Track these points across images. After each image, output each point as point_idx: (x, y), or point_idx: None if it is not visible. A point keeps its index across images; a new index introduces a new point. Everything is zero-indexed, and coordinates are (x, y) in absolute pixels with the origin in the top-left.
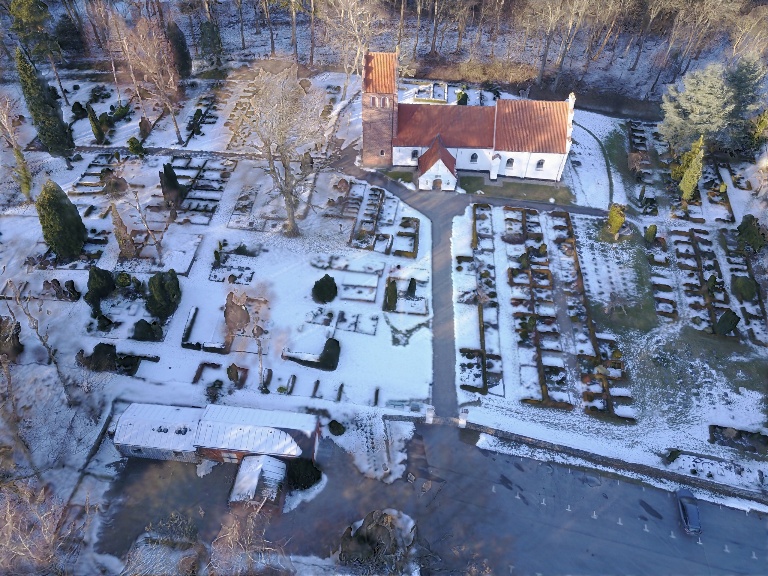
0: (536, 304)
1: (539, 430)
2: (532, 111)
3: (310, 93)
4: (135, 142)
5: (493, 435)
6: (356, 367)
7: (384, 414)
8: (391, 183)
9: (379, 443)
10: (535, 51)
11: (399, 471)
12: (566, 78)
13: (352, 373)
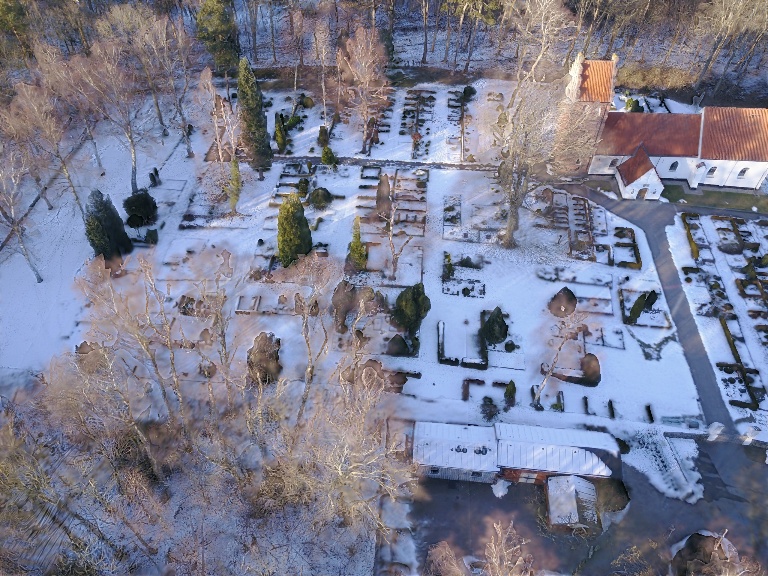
0: None
1: None
2: (740, 119)
3: (473, 100)
4: (330, 152)
5: None
6: (617, 382)
7: (665, 431)
8: (591, 192)
9: (670, 461)
10: (680, 56)
11: (699, 491)
12: (721, 83)
13: (615, 389)
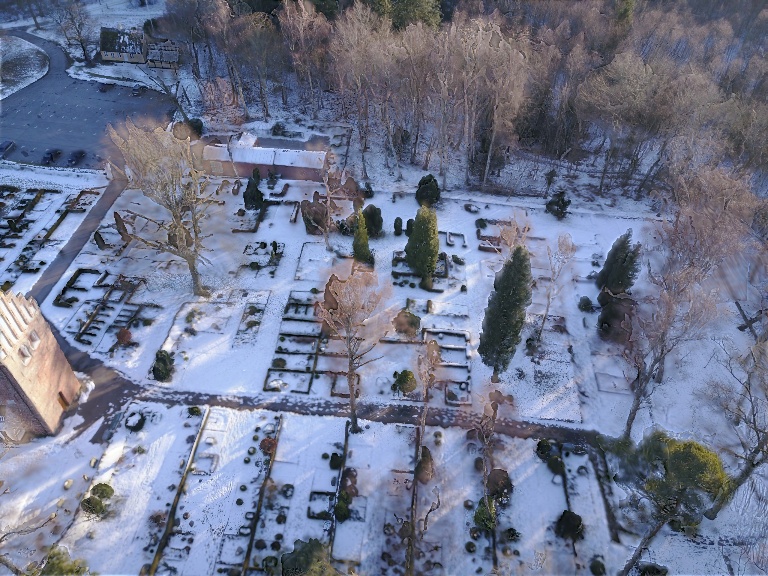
0: None
1: (61, 181)
2: None
3: None
4: None
5: None
6: None
7: None
8: None
9: None
10: None
11: None
12: None
13: None
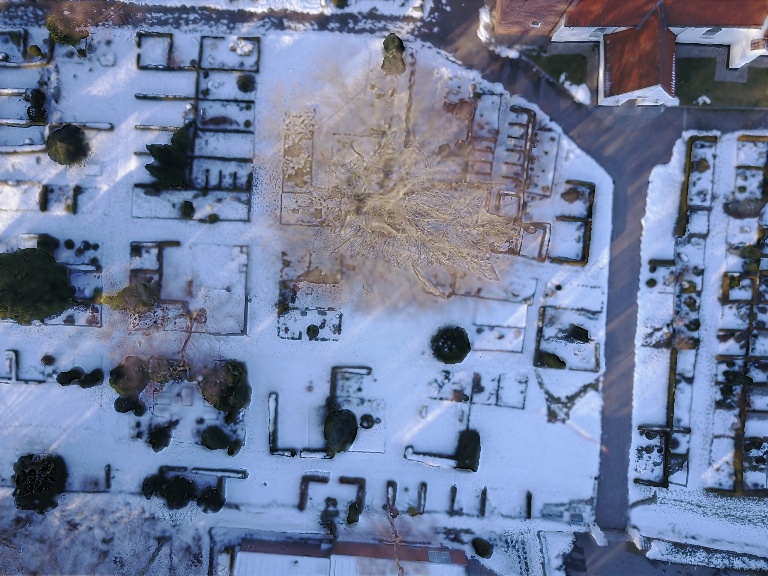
0: (753, 334)
1: (722, 528)
2: None
3: None
4: (59, 31)
5: (667, 542)
6: (501, 461)
7: (540, 530)
8: (546, 88)
9: (534, 566)
10: None
11: None
12: None
13: (496, 469)
